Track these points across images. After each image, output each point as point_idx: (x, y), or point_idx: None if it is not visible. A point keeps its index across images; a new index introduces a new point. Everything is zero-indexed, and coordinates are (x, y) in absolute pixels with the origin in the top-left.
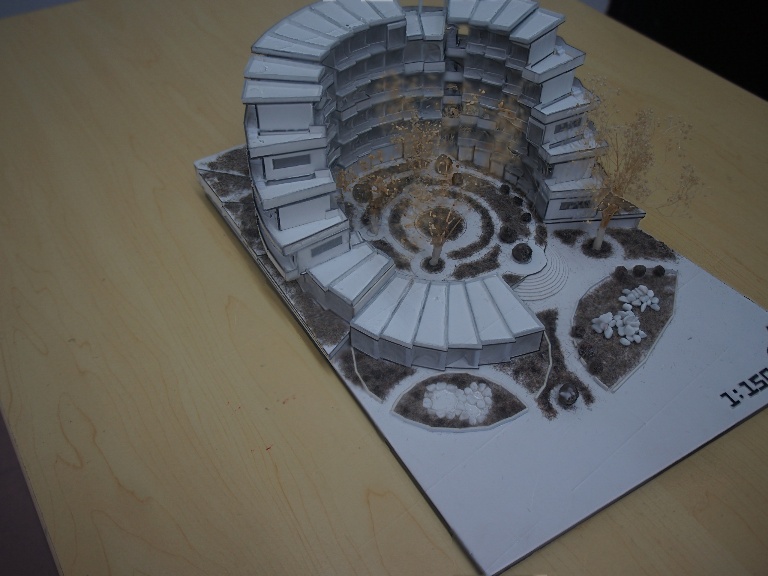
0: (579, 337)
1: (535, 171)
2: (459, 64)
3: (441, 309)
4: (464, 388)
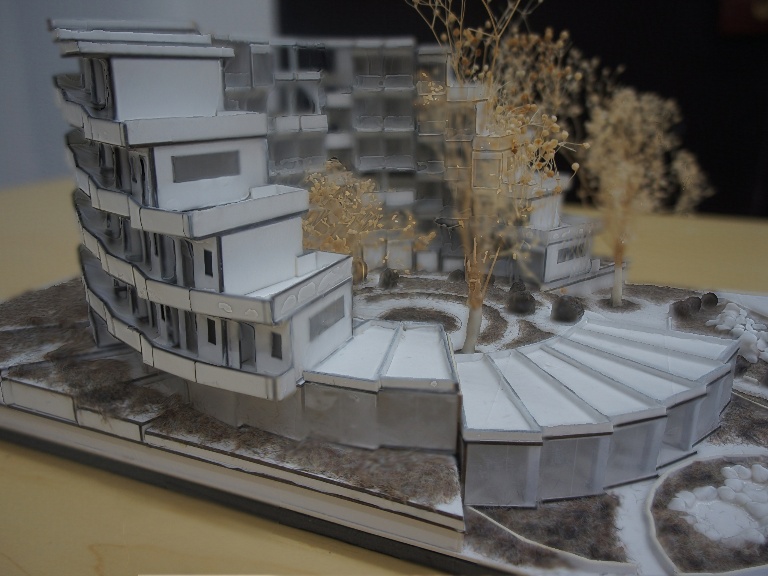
0: (743, 373)
1: (500, 227)
2: (338, 127)
3: (574, 374)
4: (723, 483)
